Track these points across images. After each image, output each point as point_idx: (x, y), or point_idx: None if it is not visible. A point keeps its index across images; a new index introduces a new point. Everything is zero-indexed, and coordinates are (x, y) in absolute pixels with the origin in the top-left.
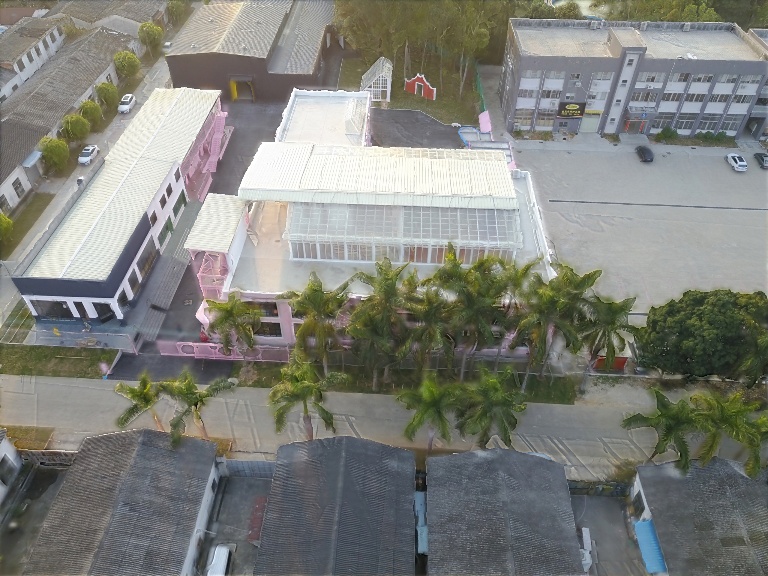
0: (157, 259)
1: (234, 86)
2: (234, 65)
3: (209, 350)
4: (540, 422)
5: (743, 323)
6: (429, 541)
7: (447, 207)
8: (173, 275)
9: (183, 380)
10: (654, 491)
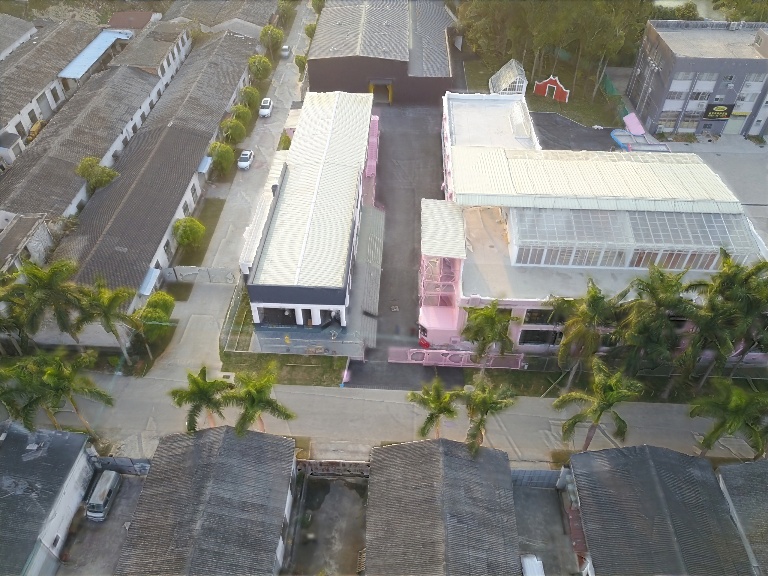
0: (354, 265)
1: (371, 89)
2: (375, 68)
3: (440, 357)
4: None
5: None
6: (755, 552)
7: (672, 211)
8: (372, 281)
9: (481, 389)
10: None
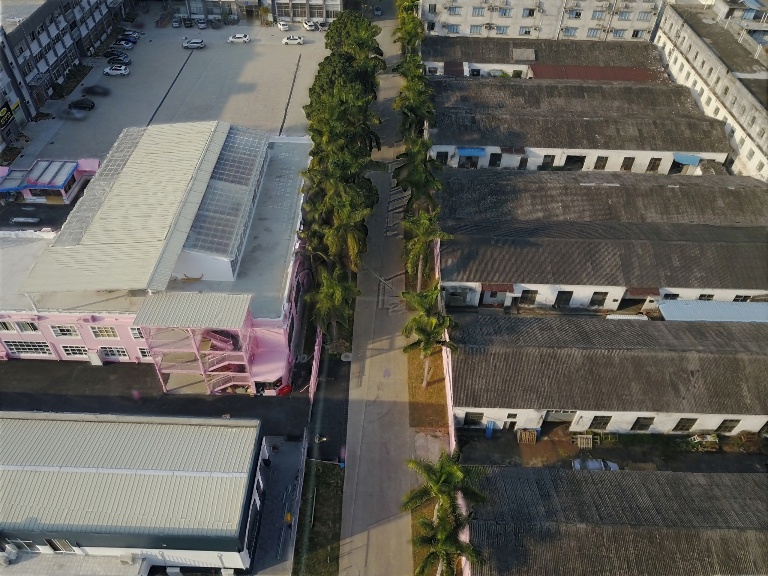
0: None
1: None
2: None
3: None
4: (379, 194)
5: (357, 69)
6: None
7: (219, 156)
8: None
9: None
10: (445, 141)
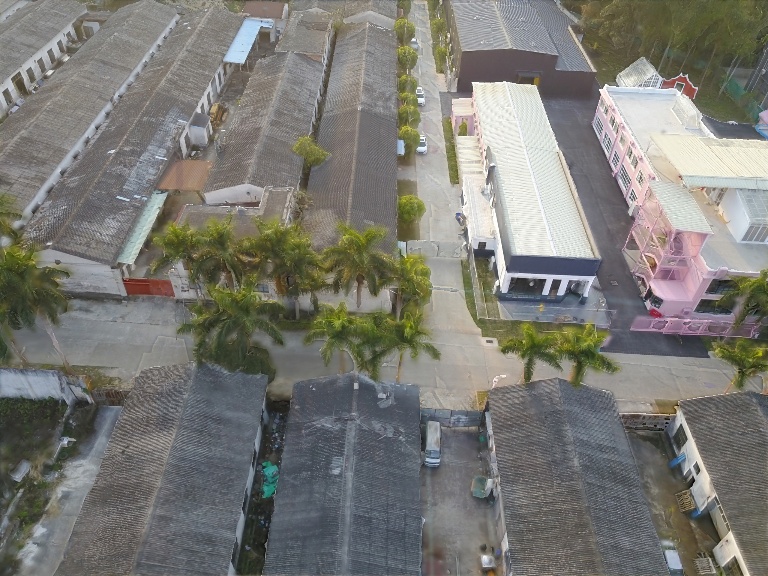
0: None
1: None
2: (525, 61)
3: (681, 326)
4: None
5: None
6: None
7: None
8: None
9: None
10: None
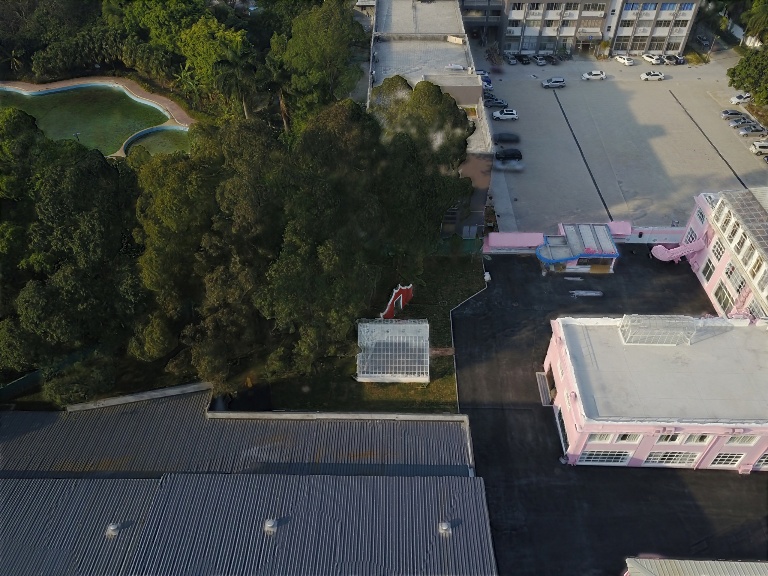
0: None
1: None
2: None
3: None
4: None
5: None
6: None
7: None
8: None
9: None
10: None
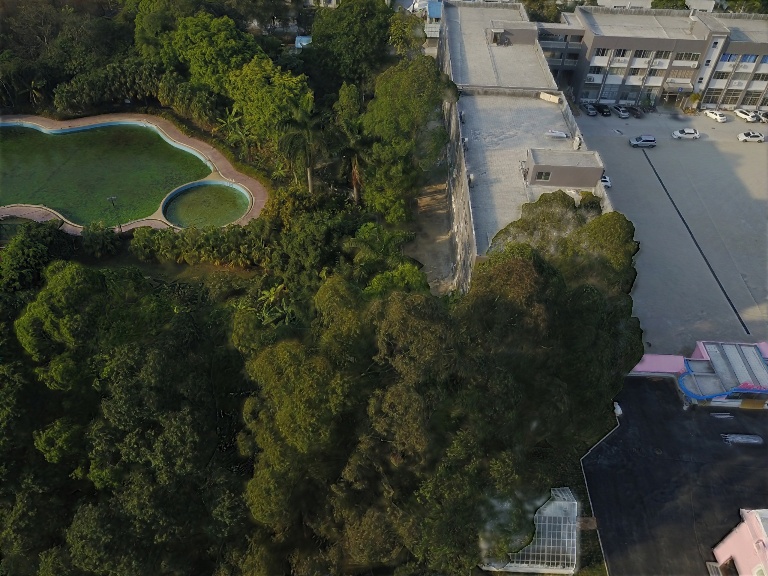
0: None
1: None
2: None
3: None
4: None
5: None
6: None
7: None
8: None
9: None
10: None
